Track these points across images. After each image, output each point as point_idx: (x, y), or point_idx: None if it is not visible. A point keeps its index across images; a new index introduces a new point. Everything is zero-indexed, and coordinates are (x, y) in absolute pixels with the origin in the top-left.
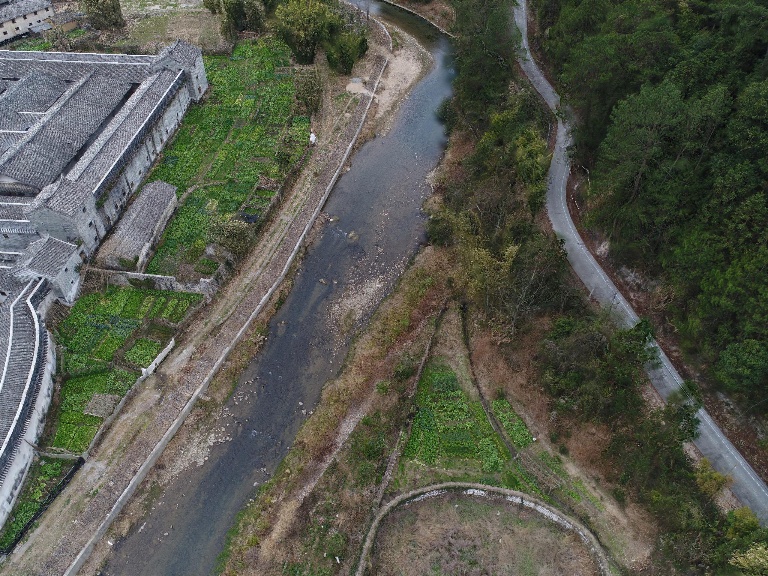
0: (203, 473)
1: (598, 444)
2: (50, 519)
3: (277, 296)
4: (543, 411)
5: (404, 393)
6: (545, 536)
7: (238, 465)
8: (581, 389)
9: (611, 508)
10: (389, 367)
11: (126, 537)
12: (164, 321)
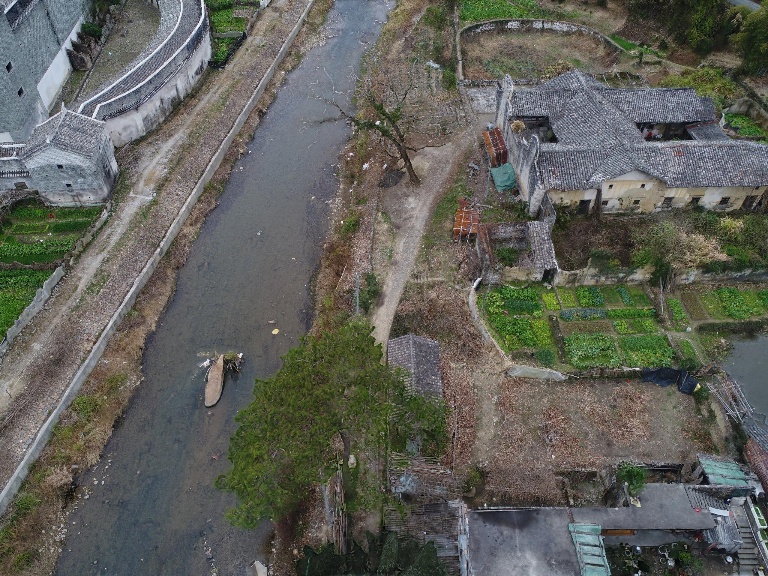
0: (327, 48)
1: None
2: None
3: None
4: None
5: None
6: (561, 39)
7: (348, 44)
8: None
9: (598, 14)
10: None
11: (292, 70)
12: None
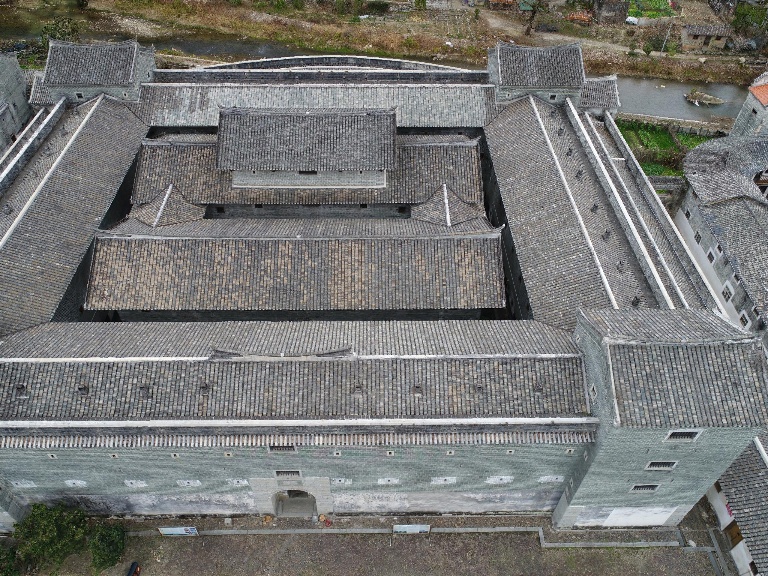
0: None
1: None
2: None
3: None
4: None
5: None
6: None
7: None
8: None
9: None
10: (219, 1)
11: None
12: None
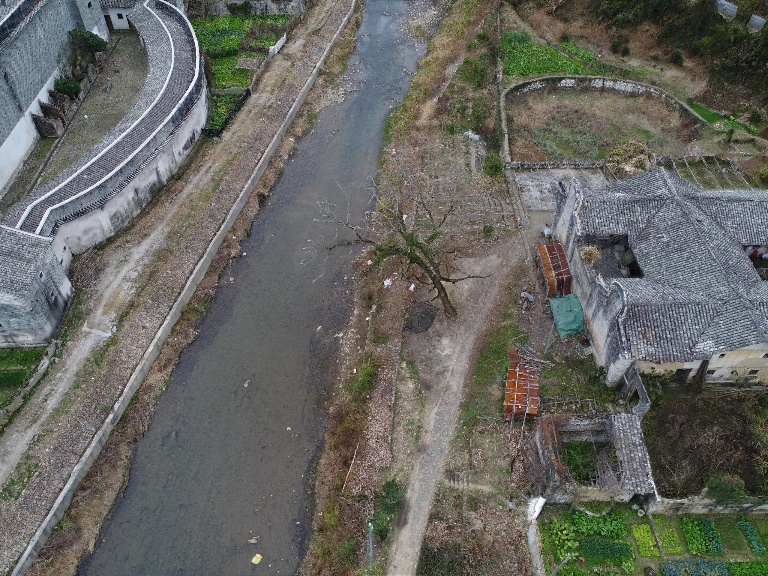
0: (345, 106)
1: (652, 37)
2: (241, 120)
3: (354, 19)
4: (603, 35)
5: (490, 46)
6: (625, 102)
7: (371, 101)
8: (633, 3)
9: (670, 72)
10: (470, 37)
11: (302, 137)
12: (272, 24)
